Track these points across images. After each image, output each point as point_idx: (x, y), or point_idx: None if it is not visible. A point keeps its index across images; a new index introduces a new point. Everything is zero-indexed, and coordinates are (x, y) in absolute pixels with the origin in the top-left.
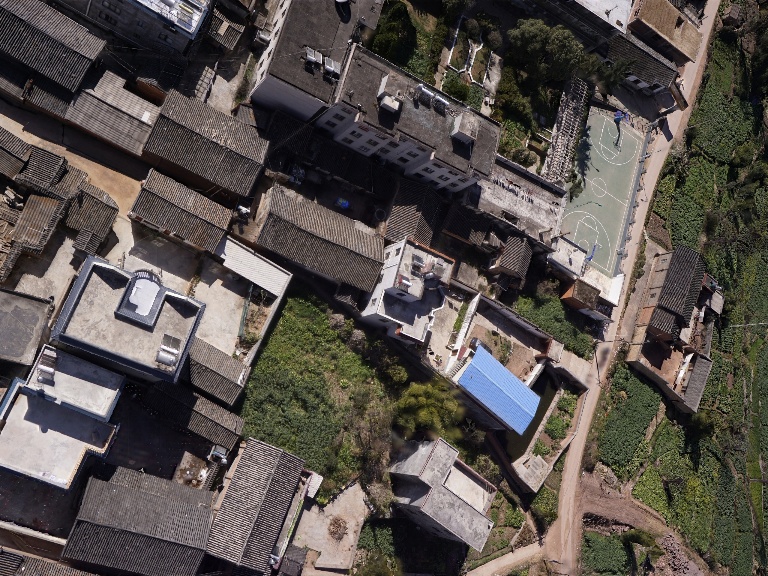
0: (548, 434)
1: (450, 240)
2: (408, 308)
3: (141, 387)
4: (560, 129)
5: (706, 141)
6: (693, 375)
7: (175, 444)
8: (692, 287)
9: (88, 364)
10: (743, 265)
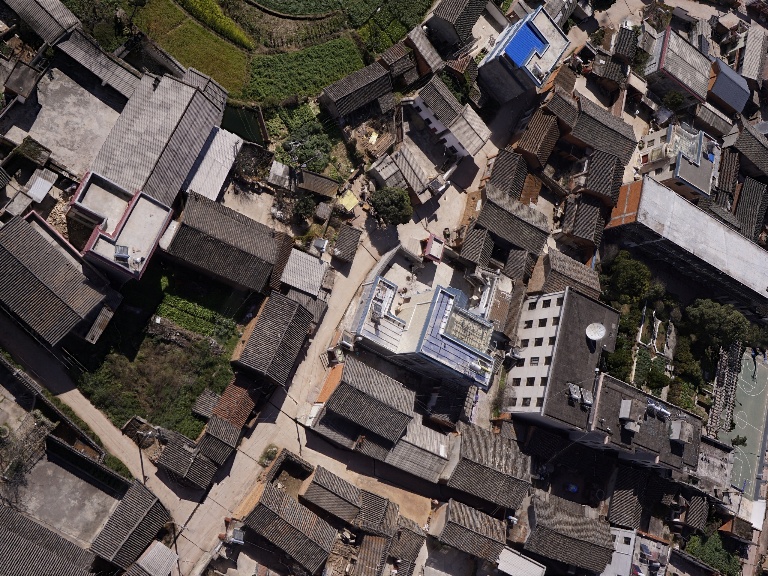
0: None
1: None
2: None
3: None
4: (720, 381)
5: None
6: None
7: None
8: None
9: None
10: None
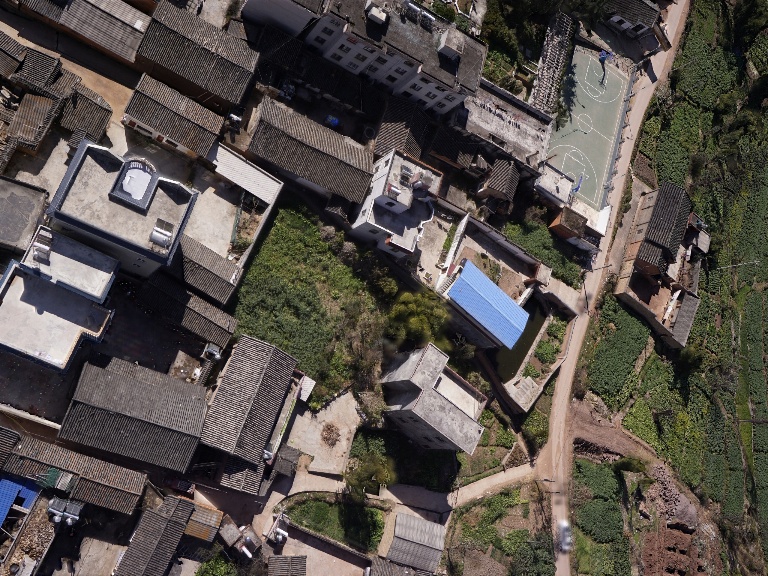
0: (538, 358)
1: (439, 164)
2: (397, 219)
3: (135, 283)
4: (546, 62)
5: (690, 86)
6: (681, 311)
7: (169, 343)
8: (678, 222)
9: (83, 247)
10: (729, 211)
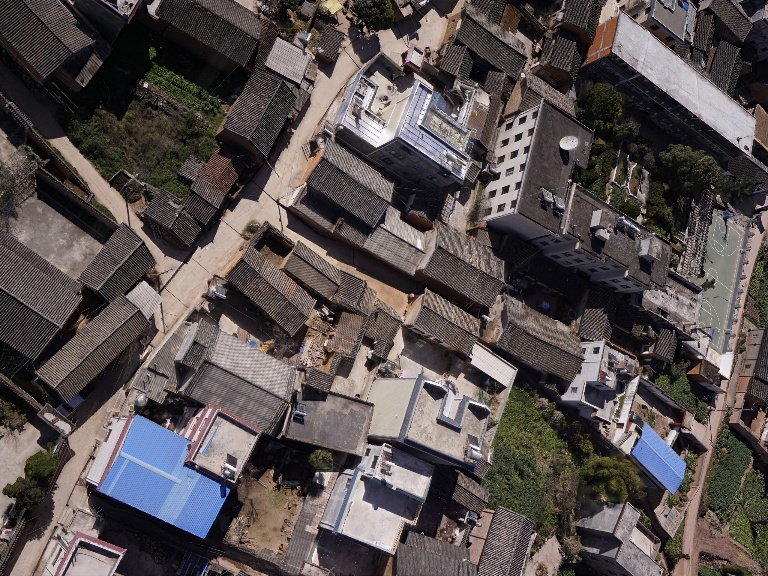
0: None
1: (614, 330)
2: (600, 395)
3: None
4: (691, 232)
5: None
6: None
7: (436, 509)
8: None
9: (411, 457)
10: None
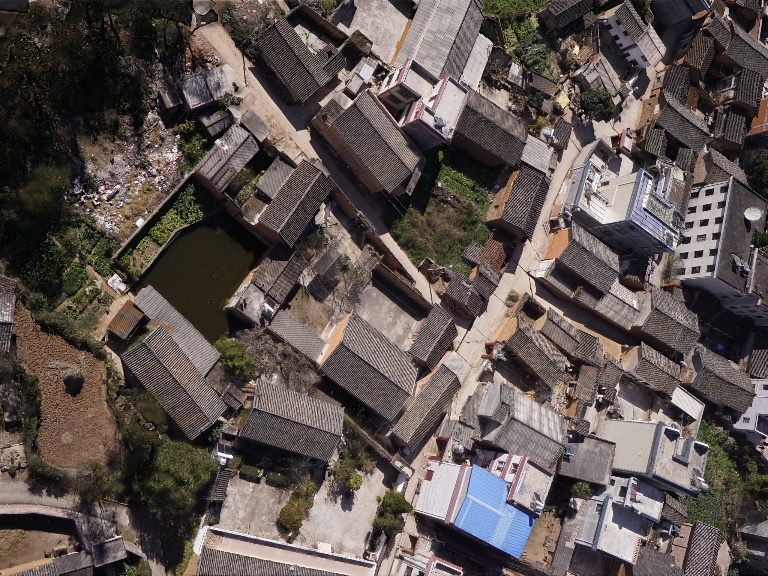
0: None
1: None
2: (767, 424)
3: None
4: None
5: None
6: None
7: None
8: None
9: (649, 487)
10: None
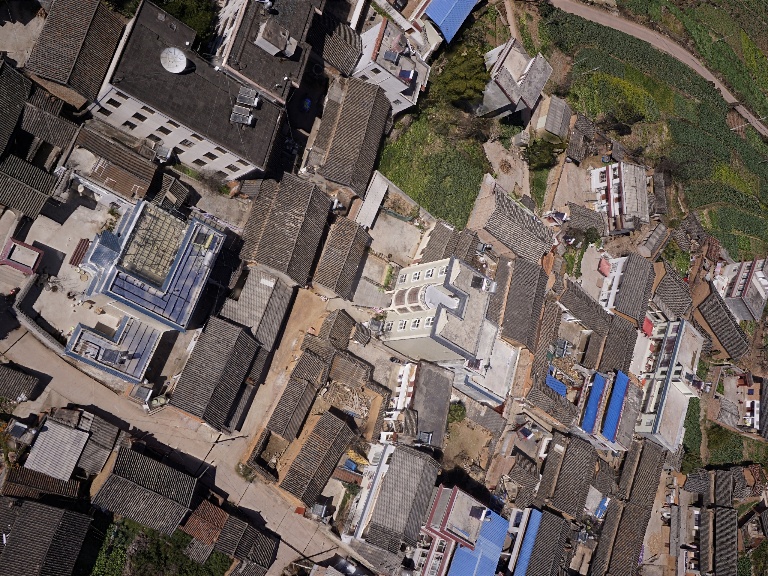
0: None
1: None
2: None
3: None
4: None
5: None
6: None
7: None
8: None
9: None
10: None
